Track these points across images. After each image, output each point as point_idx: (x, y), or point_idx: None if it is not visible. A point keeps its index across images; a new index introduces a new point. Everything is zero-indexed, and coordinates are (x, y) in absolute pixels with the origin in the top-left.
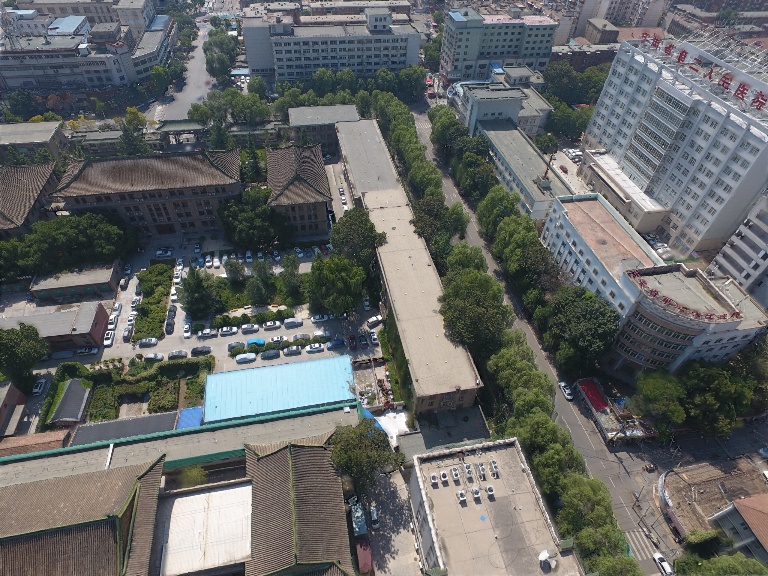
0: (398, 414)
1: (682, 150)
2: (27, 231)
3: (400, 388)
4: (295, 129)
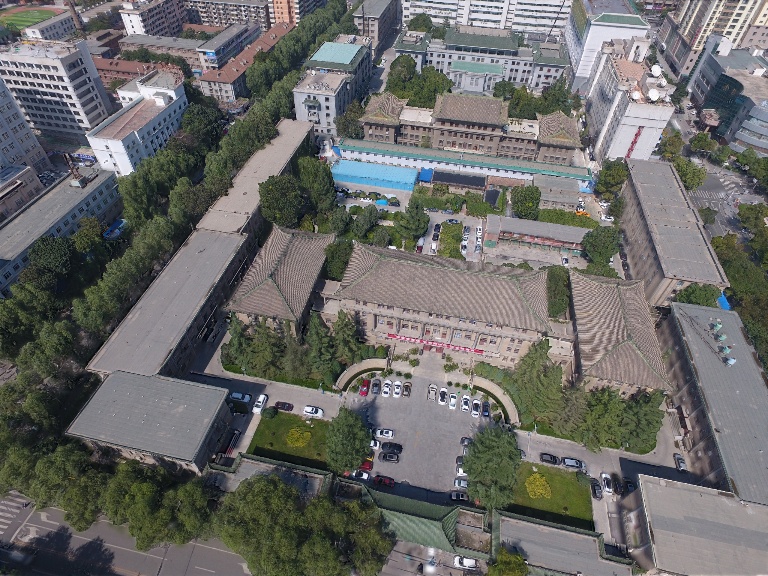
0: None
1: None
2: (569, 287)
3: None
4: None
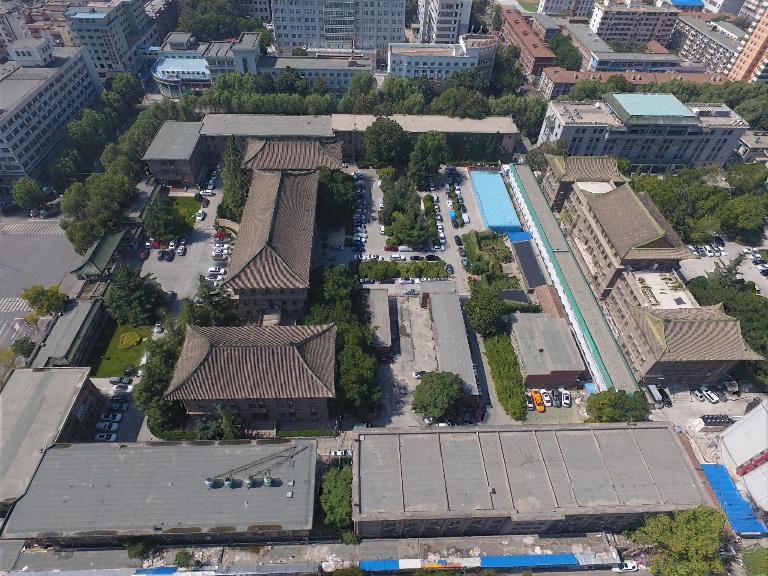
0: (503, 166)
1: (362, 11)
2: None
3: (489, 161)
4: (188, 161)
